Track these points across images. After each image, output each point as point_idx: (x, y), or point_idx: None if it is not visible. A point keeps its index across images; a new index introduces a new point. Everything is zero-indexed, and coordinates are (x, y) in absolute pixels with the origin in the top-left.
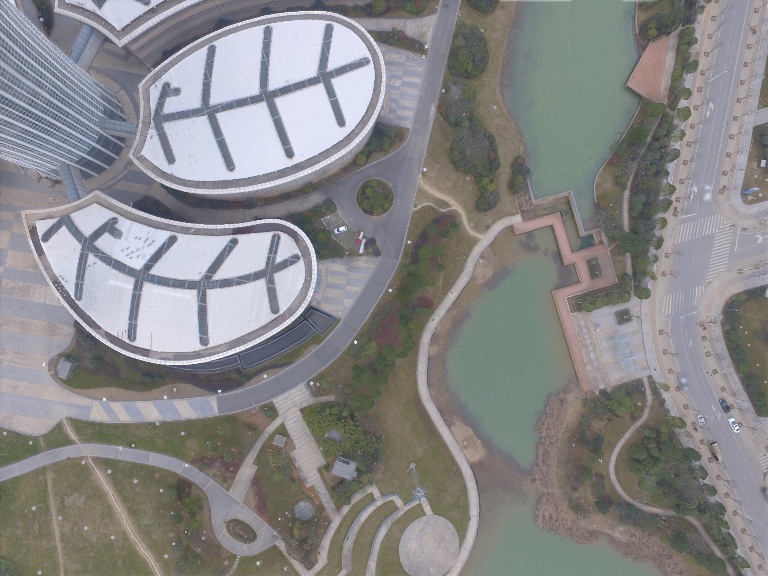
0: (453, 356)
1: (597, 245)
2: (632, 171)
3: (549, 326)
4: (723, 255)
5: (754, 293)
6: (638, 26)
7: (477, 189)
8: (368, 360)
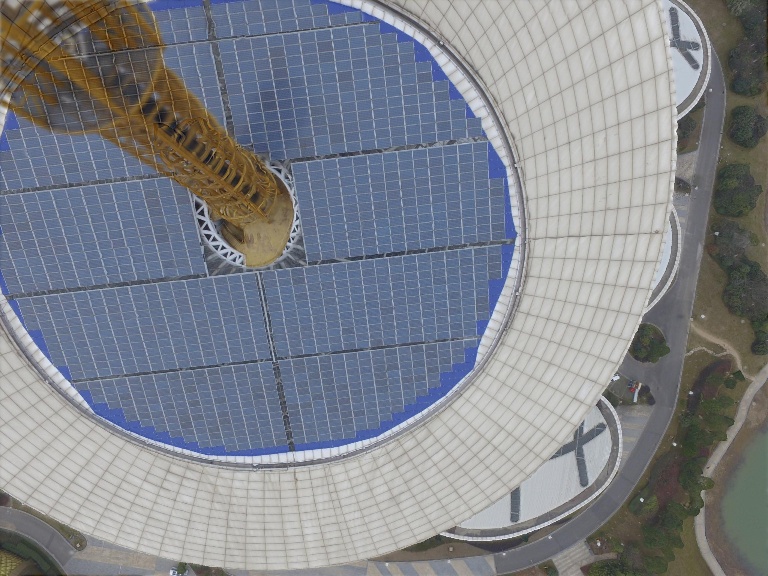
0: (729, 505)
1: None
2: None
3: None
4: None
5: None
6: None
7: (752, 332)
8: (648, 515)
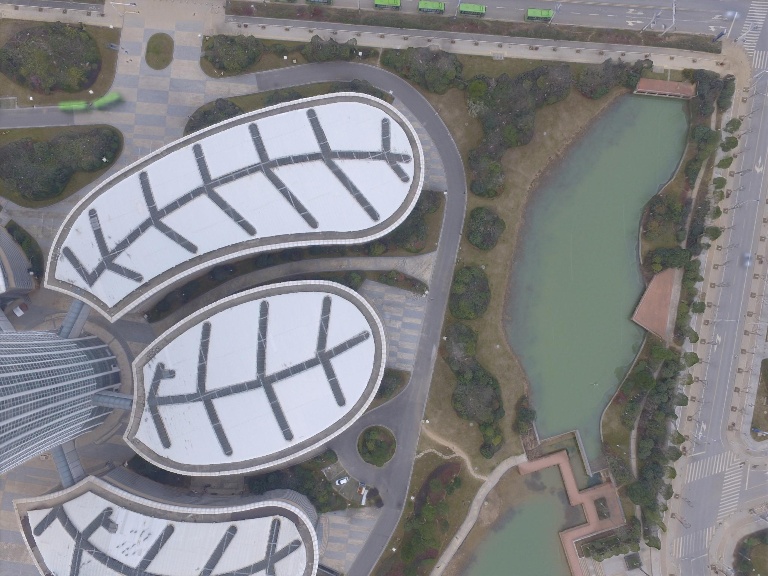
0: None
1: (604, 484)
2: (639, 414)
3: (556, 557)
4: (733, 494)
5: (766, 542)
6: (642, 256)
7: (481, 435)
8: None
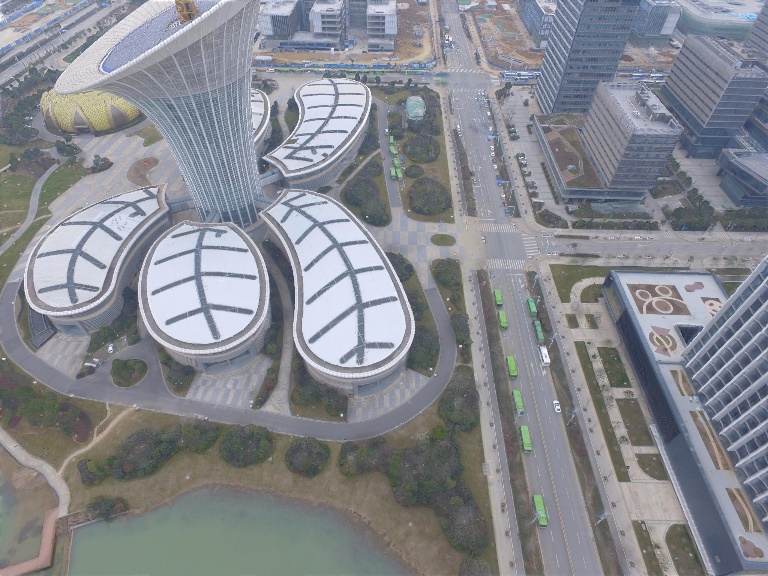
0: None
1: None
2: None
3: None
4: None
5: None
6: None
7: None
8: None
